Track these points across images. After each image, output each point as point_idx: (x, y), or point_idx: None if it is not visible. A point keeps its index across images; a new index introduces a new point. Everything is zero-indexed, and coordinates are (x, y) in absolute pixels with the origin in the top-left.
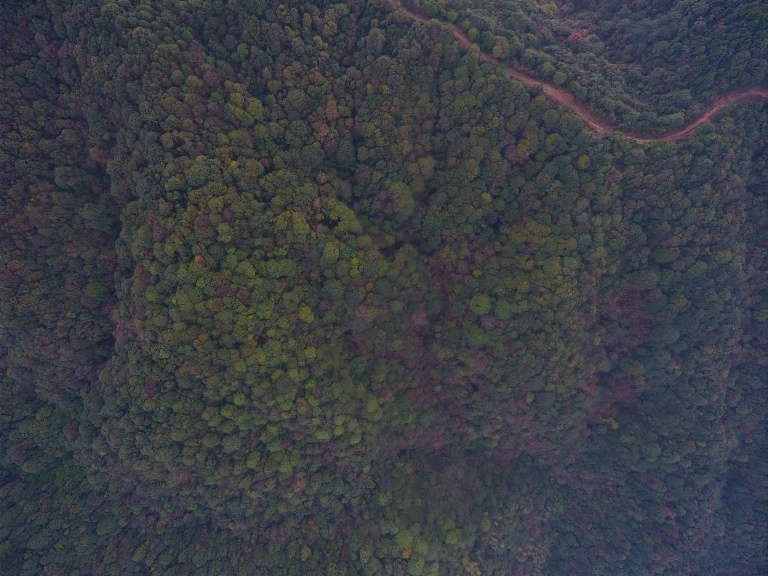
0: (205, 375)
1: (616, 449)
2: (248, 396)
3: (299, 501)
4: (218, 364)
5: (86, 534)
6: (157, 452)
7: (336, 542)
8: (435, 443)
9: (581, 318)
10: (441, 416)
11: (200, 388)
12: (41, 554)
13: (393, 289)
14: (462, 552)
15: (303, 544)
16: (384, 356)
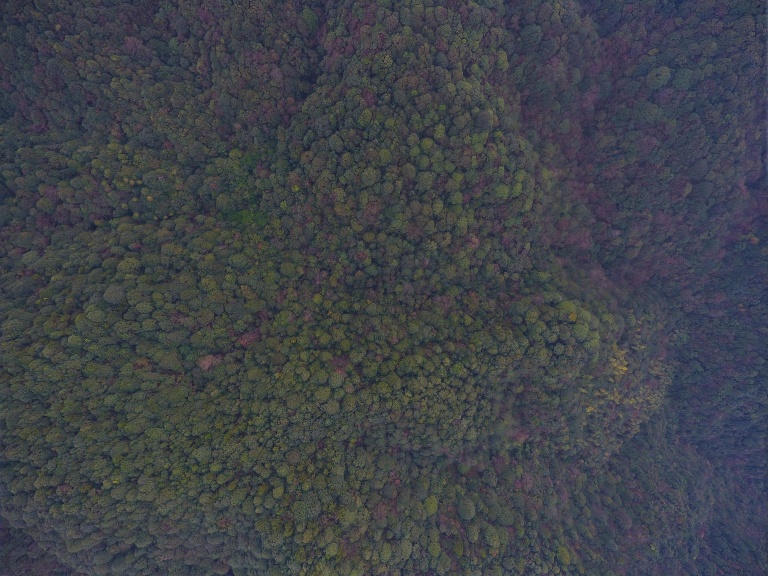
0: (420, 92)
1: (755, 263)
2: (445, 133)
3: (469, 264)
4: (432, 82)
5: (272, 270)
6: (364, 171)
7: (497, 313)
8: (583, 242)
9: (752, 99)
10: (589, 217)
11: (412, 107)
12: (238, 274)
13: (579, 52)
14: (613, 337)
15: (464, 314)
16: (551, 137)
